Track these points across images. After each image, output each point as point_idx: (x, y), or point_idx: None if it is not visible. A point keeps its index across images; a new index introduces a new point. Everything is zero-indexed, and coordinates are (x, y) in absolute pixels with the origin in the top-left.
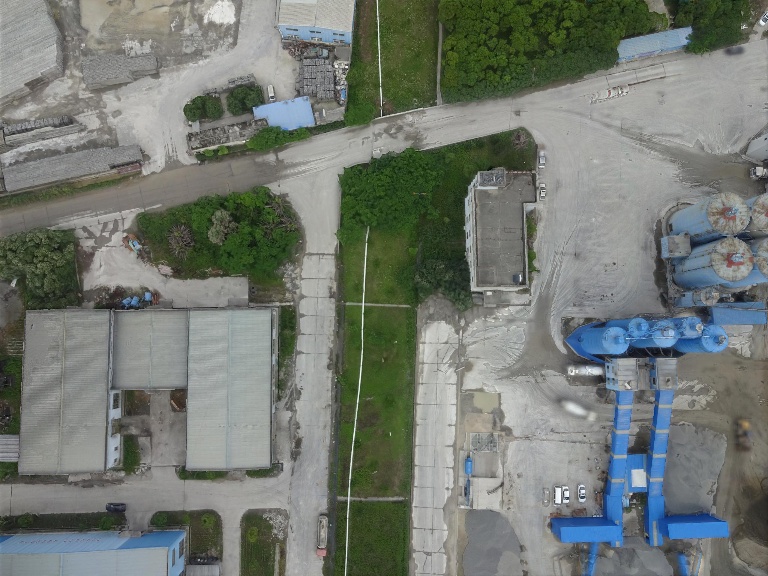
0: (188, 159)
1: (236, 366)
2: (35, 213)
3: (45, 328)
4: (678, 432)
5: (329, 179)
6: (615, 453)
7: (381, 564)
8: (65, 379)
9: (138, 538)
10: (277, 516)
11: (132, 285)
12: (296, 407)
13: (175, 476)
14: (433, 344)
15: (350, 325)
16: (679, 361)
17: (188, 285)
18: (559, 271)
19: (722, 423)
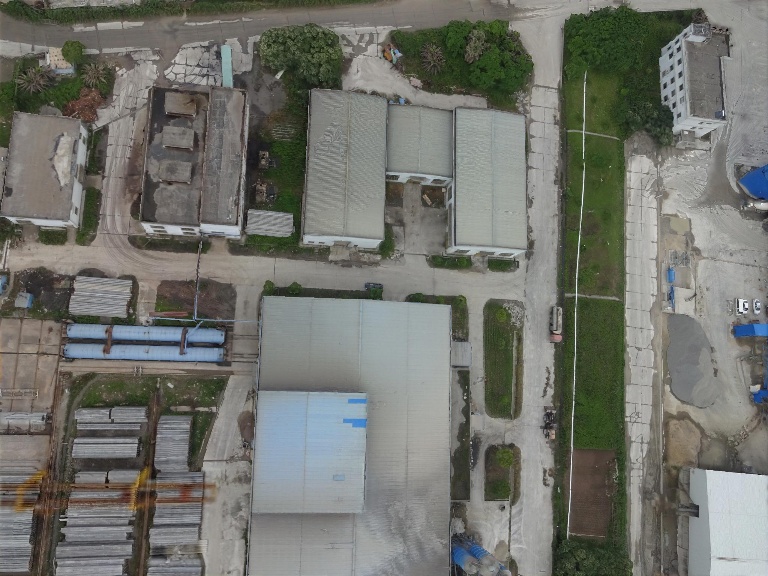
0: None
1: (498, 159)
2: (298, 17)
3: (324, 109)
4: None
5: (553, 25)
6: None
7: (605, 352)
8: (350, 152)
9: None
10: (514, 307)
11: (386, 92)
12: (529, 214)
13: (426, 264)
14: (637, 173)
15: (573, 148)
16: None
17: (435, 98)
18: (731, 127)
19: None
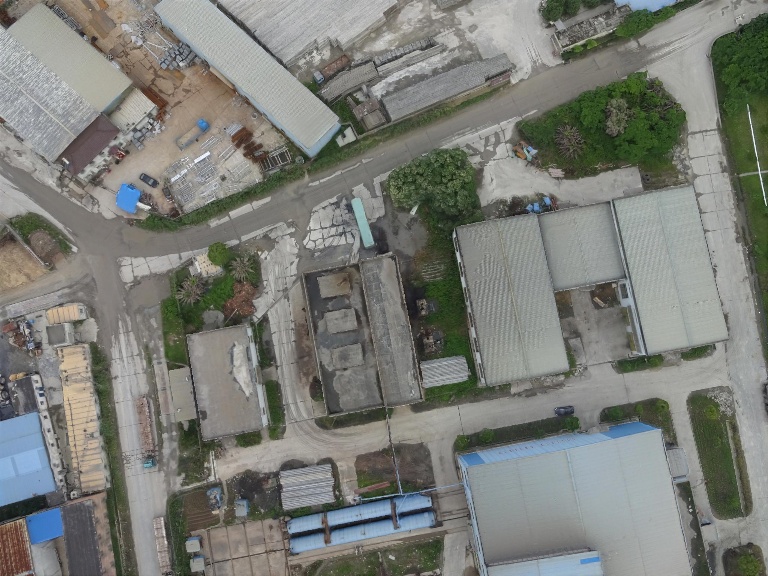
0: (553, 60)
1: (674, 246)
2: (416, 139)
3: (473, 243)
4: None
5: (696, 55)
6: None
7: None
8: (513, 286)
9: (609, 431)
10: (720, 394)
11: (527, 193)
12: None
13: (613, 371)
14: None
15: (751, 195)
16: None
17: (581, 184)
18: None
19: None
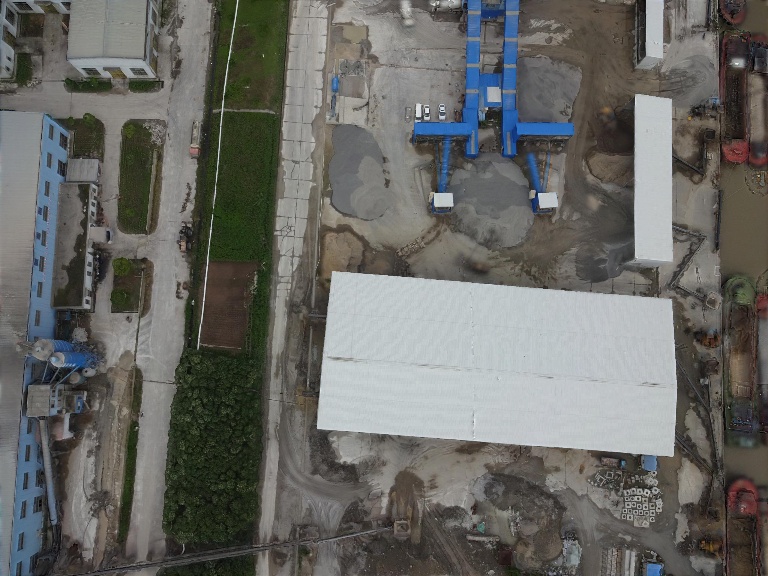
0: None
1: None
2: None
3: None
4: (534, 61)
5: None
6: (468, 61)
7: (250, 164)
8: None
9: None
10: (156, 126)
11: None
12: (177, 34)
13: (63, 89)
14: None
15: None
16: (537, 3)
17: None
18: None
19: (578, 57)
